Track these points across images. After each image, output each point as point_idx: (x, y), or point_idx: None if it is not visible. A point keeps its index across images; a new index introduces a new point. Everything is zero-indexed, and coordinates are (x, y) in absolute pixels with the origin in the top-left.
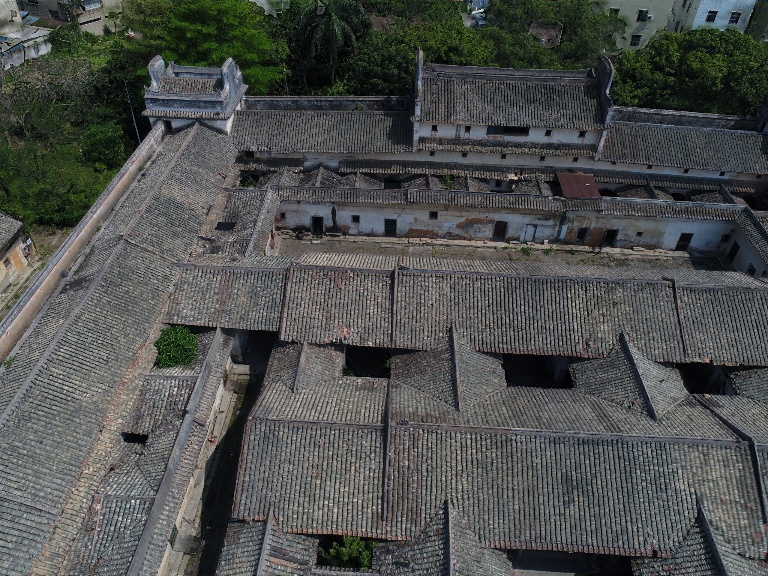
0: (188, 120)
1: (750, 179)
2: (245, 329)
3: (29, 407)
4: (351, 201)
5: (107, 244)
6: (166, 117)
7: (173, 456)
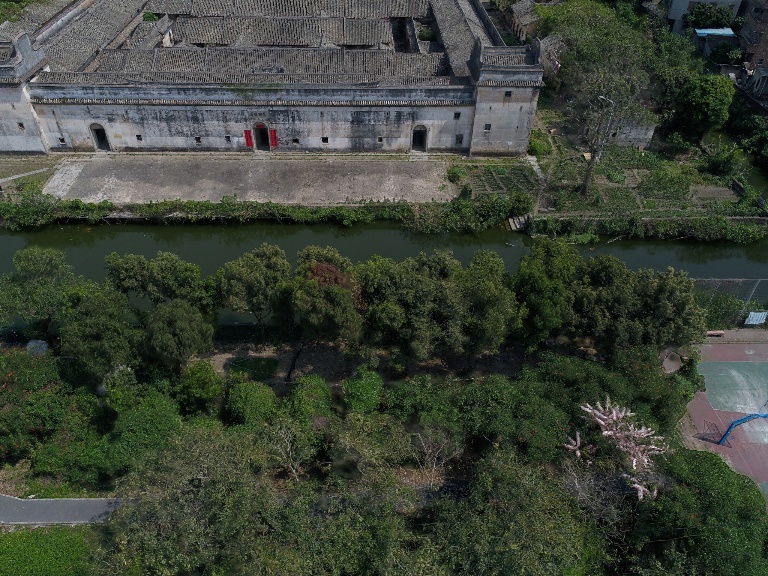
0: None
1: None
2: (177, 14)
3: (104, 7)
4: None
5: None
6: None
7: None
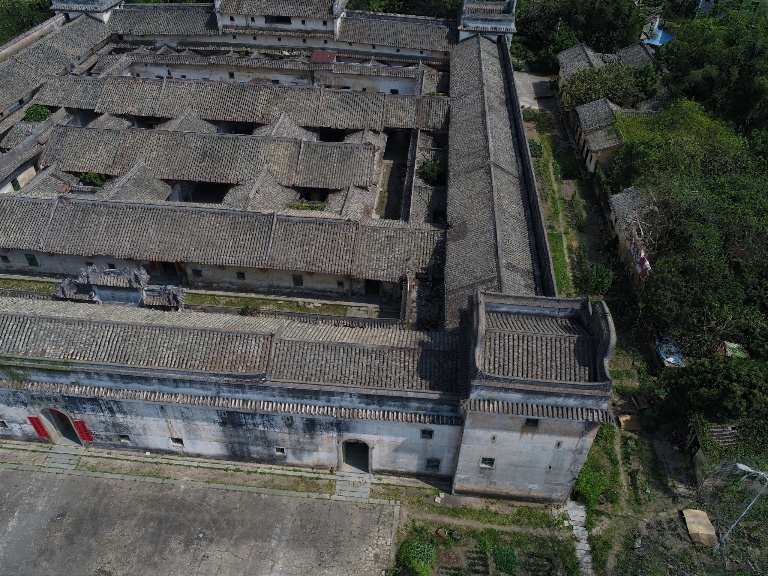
0: (79, 13)
1: (441, 57)
2: (78, 108)
3: None
4: (176, 63)
5: (6, 62)
6: (65, 10)
7: (18, 147)
